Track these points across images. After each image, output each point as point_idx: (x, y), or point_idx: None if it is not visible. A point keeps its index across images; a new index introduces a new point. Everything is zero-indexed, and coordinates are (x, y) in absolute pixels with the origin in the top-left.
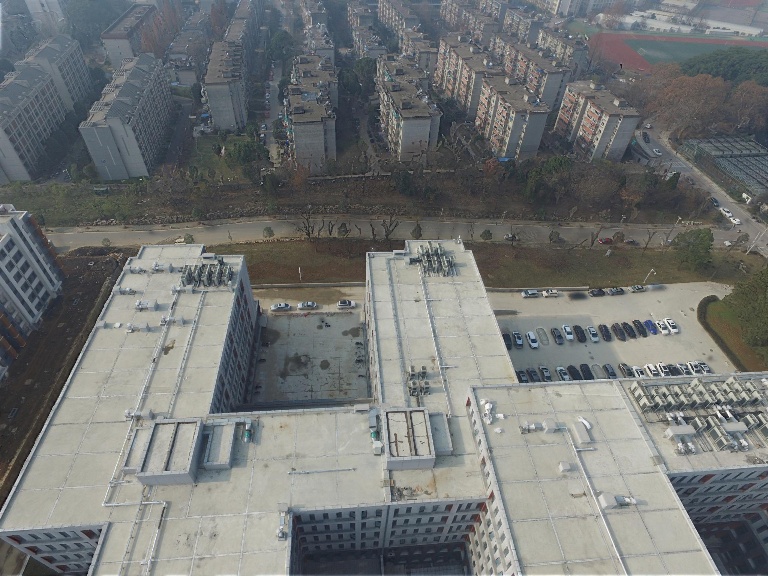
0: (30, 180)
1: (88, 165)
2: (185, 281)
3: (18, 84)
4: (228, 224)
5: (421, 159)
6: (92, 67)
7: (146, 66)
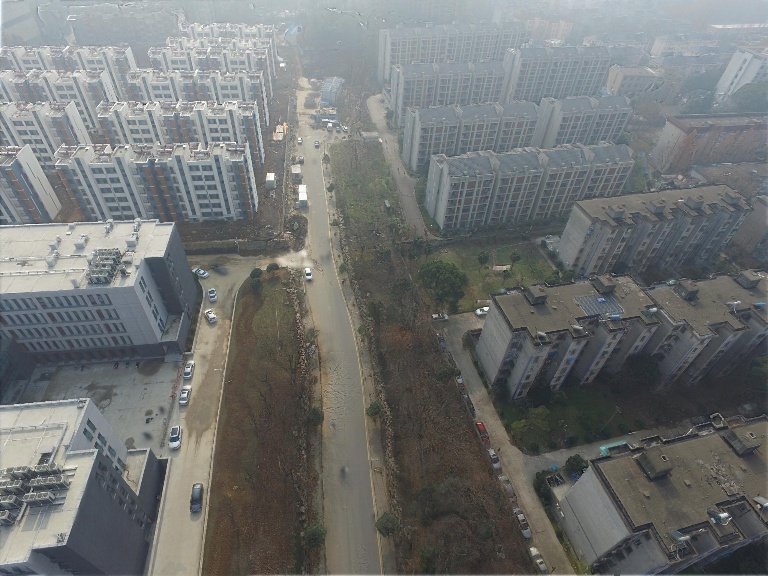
0: (415, 171)
1: (424, 186)
2: (99, 254)
3: (495, 108)
4: (345, 301)
5: (585, 550)
6: (625, 137)
7: (593, 155)
